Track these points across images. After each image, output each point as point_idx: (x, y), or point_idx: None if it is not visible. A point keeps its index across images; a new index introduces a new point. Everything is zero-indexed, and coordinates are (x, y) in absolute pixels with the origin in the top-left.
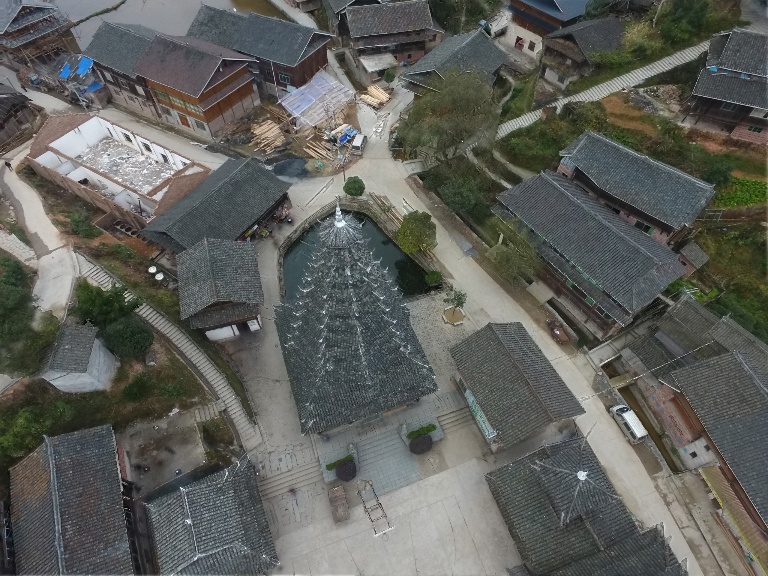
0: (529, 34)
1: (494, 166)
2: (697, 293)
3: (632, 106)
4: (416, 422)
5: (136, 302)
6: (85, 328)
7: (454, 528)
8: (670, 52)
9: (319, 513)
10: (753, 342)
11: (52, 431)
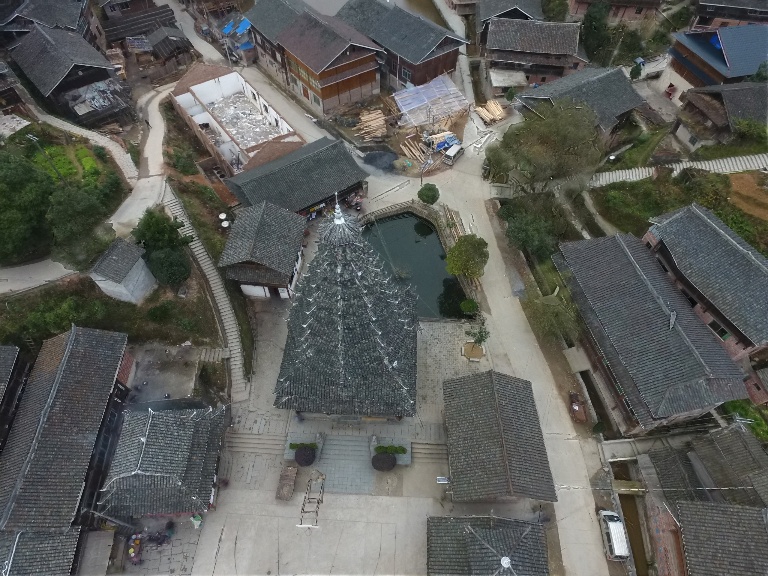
0: (684, 83)
1: (582, 213)
2: (763, 427)
3: (766, 191)
4: (390, 439)
5: (186, 239)
6: (135, 247)
7: (381, 555)
8: None
9: (268, 483)
10: None
11: (86, 323)
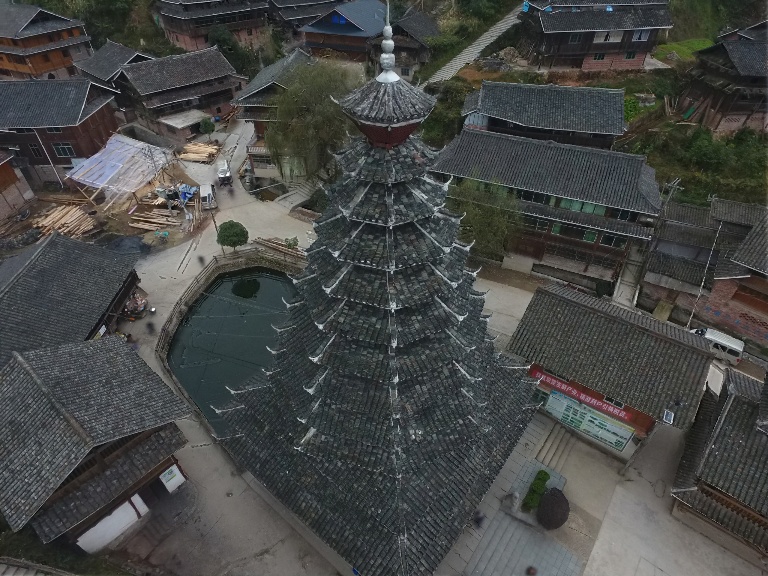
0: None
1: None
2: None
3: (487, 70)
4: (517, 482)
5: None
6: None
7: None
8: (485, 28)
9: None
10: (755, 205)
11: None
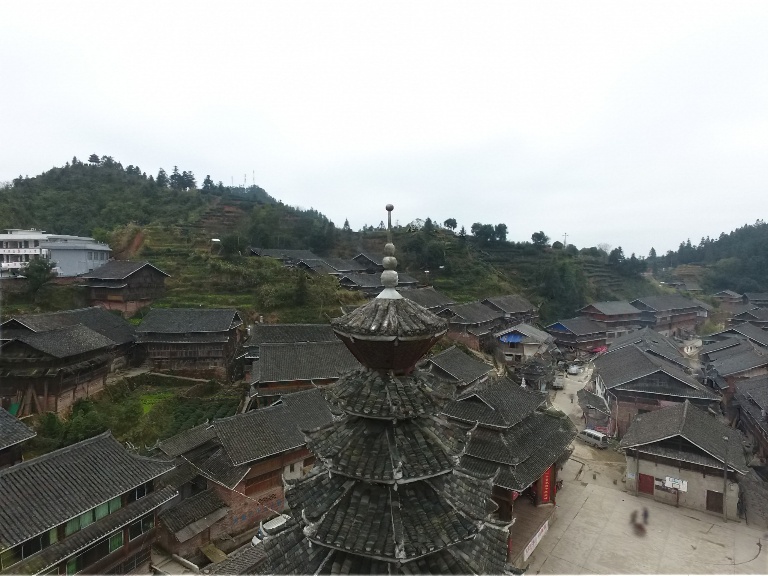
0: None
1: None
2: None
3: None
4: None
5: None
6: None
7: None
8: None
9: None
10: (186, 432)
11: None
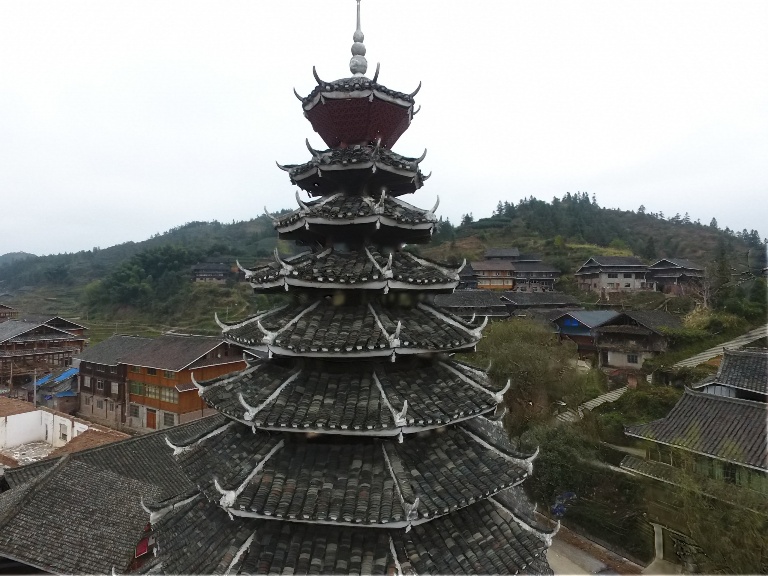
0: None
1: None
2: None
3: None
4: None
5: None
6: None
7: None
8: (751, 327)
9: None
10: None
11: None
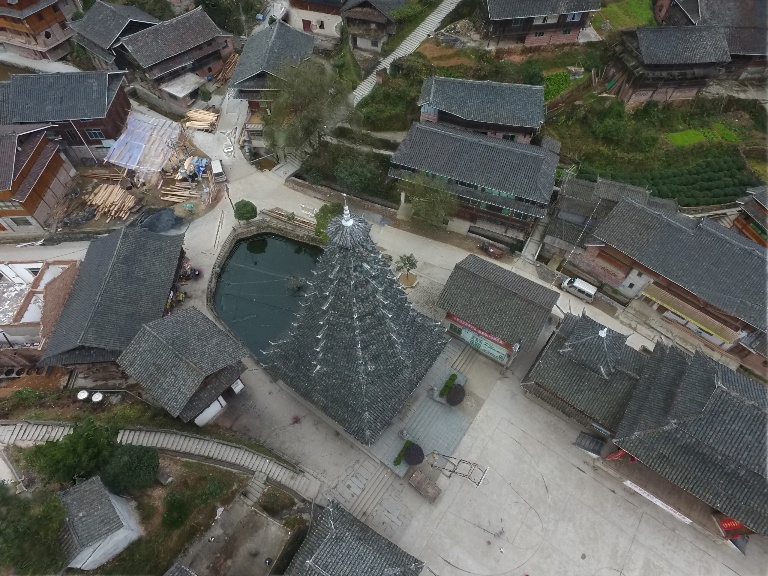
0: (313, 14)
1: None
2: None
3: (445, 46)
4: (438, 381)
5: (116, 428)
6: (85, 484)
7: (520, 442)
8: None
9: (413, 506)
10: (625, 187)
11: None
